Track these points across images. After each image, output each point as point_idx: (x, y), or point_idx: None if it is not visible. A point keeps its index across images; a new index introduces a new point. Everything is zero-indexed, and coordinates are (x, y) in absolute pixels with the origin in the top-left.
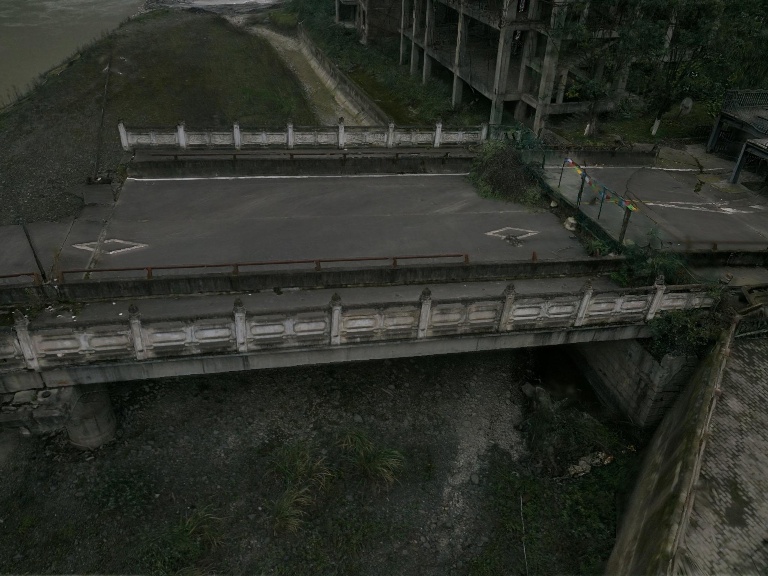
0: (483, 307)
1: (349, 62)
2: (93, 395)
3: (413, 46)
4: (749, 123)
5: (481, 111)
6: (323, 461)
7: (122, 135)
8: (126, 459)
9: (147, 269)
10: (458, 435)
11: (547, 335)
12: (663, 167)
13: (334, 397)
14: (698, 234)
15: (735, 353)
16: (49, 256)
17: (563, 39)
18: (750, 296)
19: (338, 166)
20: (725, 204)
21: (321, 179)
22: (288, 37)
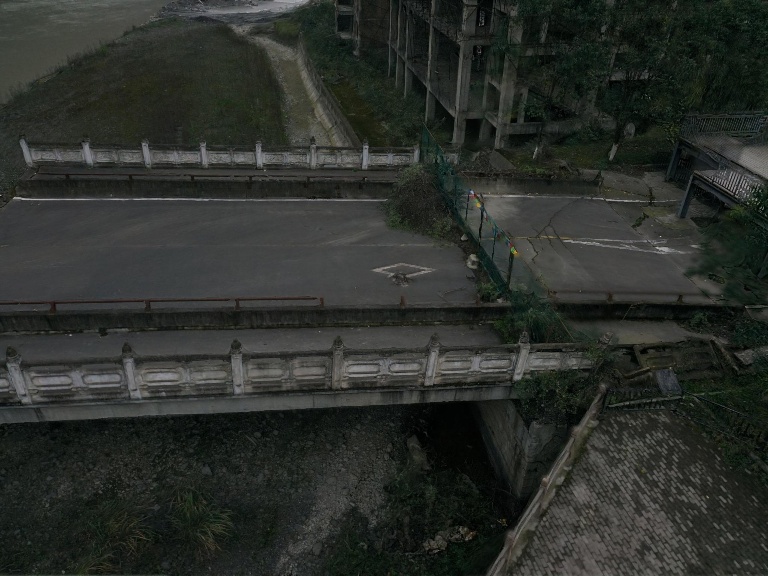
0: (308, 363)
1: (336, 74)
2: None
3: (397, 58)
4: (705, 151)
5: (445, 129)
6: (137, 523)
7: (25, 151)
8: None
9: None
10: (317, 494)
11: (397, 393)
12: (607, 197)
13: (191, 443)
14: (611, 278)
15: (604, 427)
16: None
17: (521, 55)
18: (641, 357)
19: (244, 189)
20: (662, 242)
21: (222, 203)
22: (287, 47)
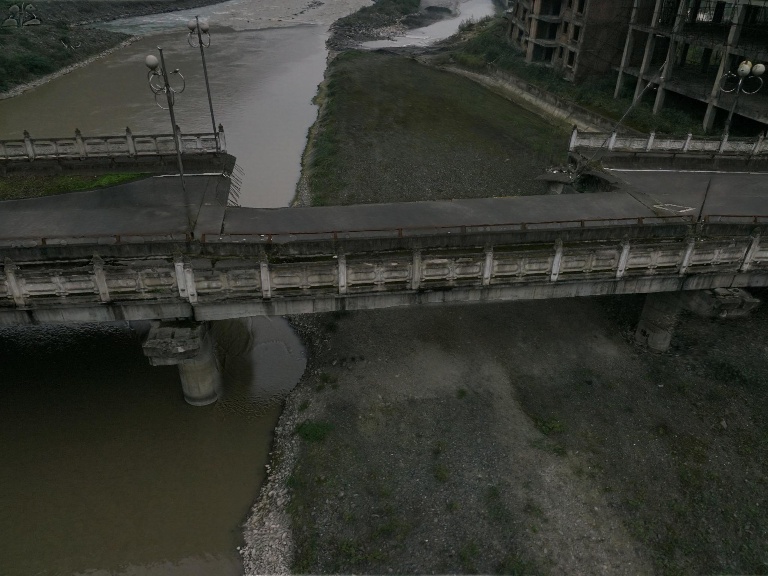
0: None
1: (569, 96)
2: (635, 319)
3: (640, 82)
4: None
5: (755, 134)
6: None
7: (573, 139)
8: (709, 356)
9: (755, 217)
10: None
11: None
12: None
13: None
14: None
15: None
16: (647, 211)
17: None
18: None
19: (743, 165)
20: None
21: (737, 174)
22: (482, 75)
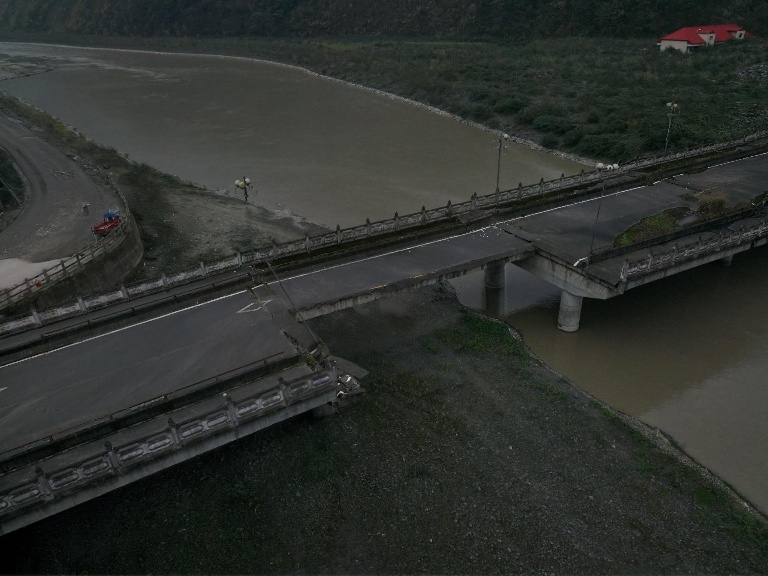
0: None
1: None
2: None
3: None
4: None
5: None
6: None
7: None
8: None
9: None
10: None
11: None
12: None
13: None
14: None
15: None
16: None
17: None
18: None
19: None
20: None
21: None
22: None
